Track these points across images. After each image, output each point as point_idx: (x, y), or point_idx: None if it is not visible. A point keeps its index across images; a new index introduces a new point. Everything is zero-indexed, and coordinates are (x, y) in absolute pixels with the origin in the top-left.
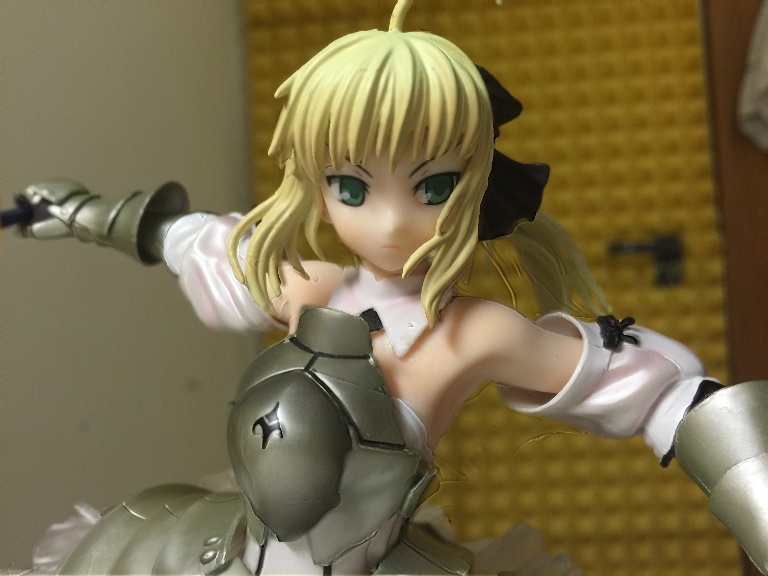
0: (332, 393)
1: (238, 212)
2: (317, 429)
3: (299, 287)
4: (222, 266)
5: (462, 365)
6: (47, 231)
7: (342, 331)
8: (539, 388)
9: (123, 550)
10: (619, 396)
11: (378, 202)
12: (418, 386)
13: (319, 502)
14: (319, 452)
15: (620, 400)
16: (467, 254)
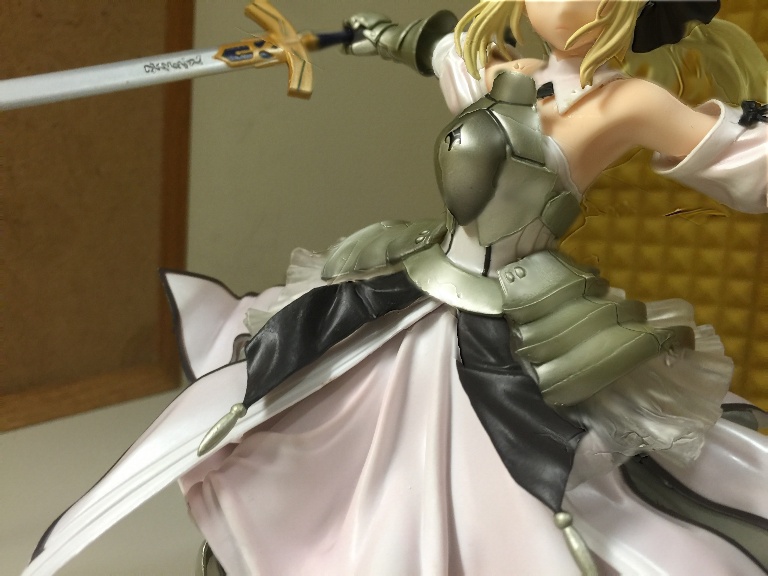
0: (500, 124)
1: None
2: (487, 146)
3: None
4: None
5: (606, 122)
6: (361, 49)
7: (517, 87)
8: (676, 154)
9: (375, 239)
10: (742, 163)
11: None
12: (568, 133)
13: (480, 192)
14: (485, 160)
15: (741, 165)
16: (621, 35)
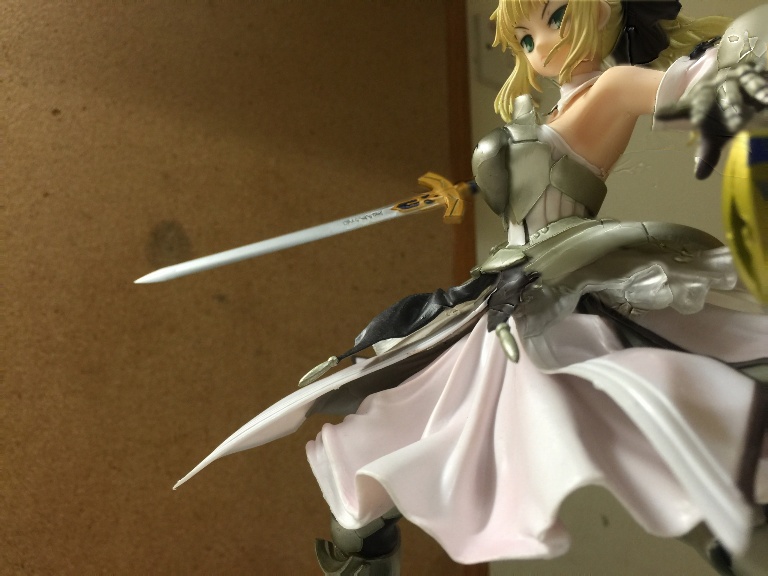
0: None
1: None
2: None
3: None
4: None
5: (588, 102)
6: None
7: None
8: None
9: None
10: None
11: None
12: None
13: (497, 175)
14: None
15: (695, 84)
16: (581, 42)
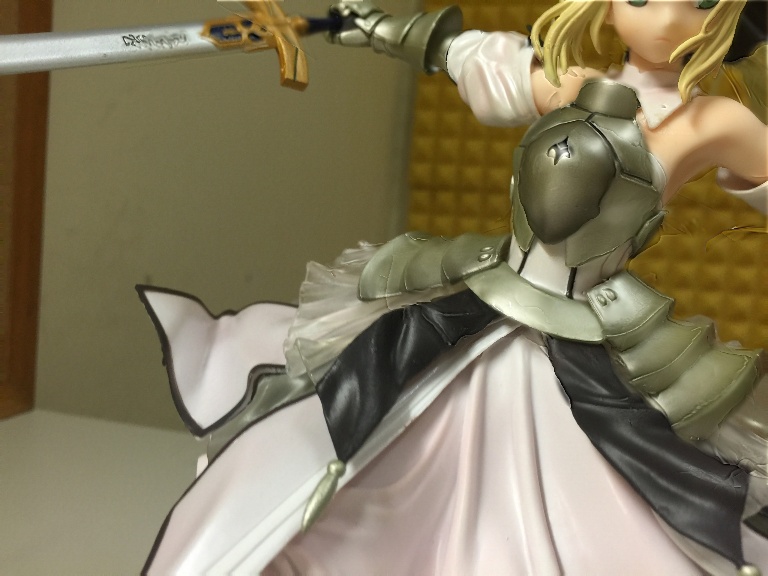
0: (605, 138)
1: (514, 29)
2: (591, 161)
3: (568, 81)
4: (501, 67)
5: (700, 140)
6: (351, 39)
7: (615, 99)
8: (756, 174)
9: (416, 254)
10: None
11: (659, 3)
12: (664, 150)
13: (585, 210)
14: (590, 176)
15: None
16: (722, 52)
